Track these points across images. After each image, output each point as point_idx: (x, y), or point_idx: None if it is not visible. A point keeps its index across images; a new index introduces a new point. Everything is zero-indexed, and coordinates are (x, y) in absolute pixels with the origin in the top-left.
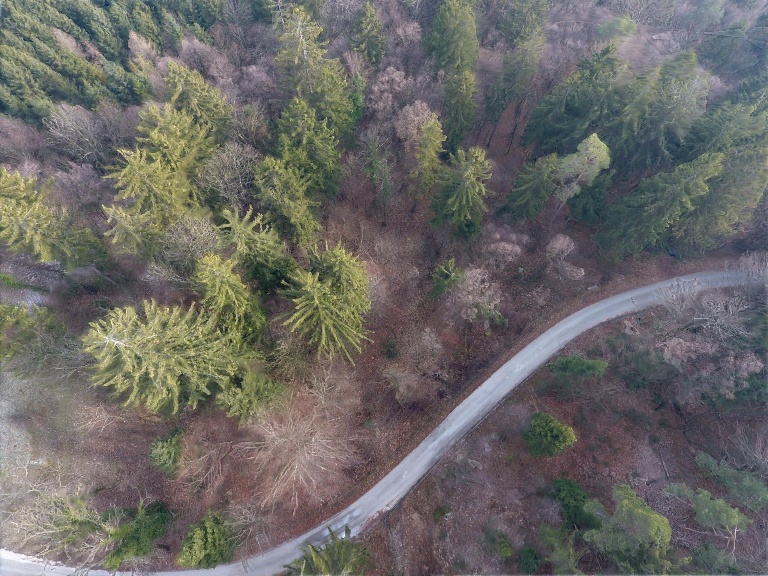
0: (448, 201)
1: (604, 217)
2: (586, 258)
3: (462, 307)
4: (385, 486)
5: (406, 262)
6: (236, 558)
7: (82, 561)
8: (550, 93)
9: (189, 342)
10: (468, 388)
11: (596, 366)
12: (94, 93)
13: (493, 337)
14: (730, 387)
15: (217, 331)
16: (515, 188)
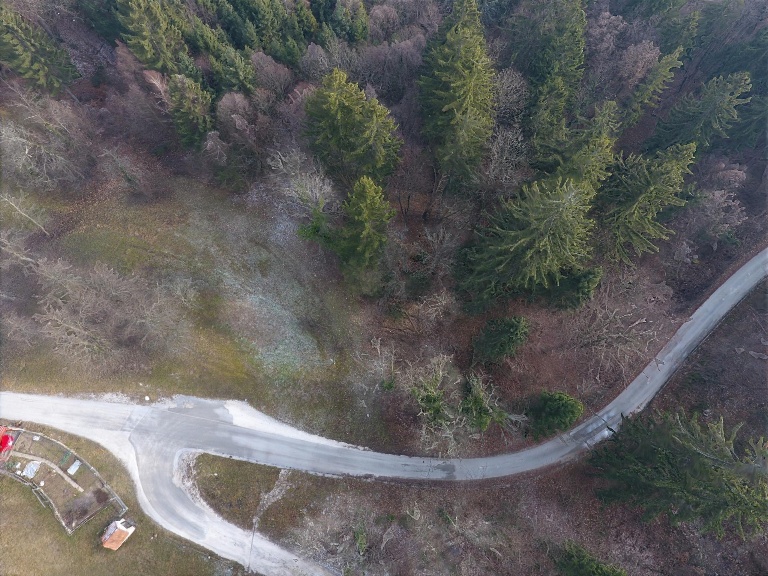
0: (696, 127)
1: None
2: None
3: (702, 227)
4: (633, 391)
5: None
6: (517, 448)
7: (386, 447)
8: (767, 34)
9: None
10: (691, 308)
11: None
12: (327, 35)
13: (702, 264)
14: None
15: (580, 216)
16: (742, 120)
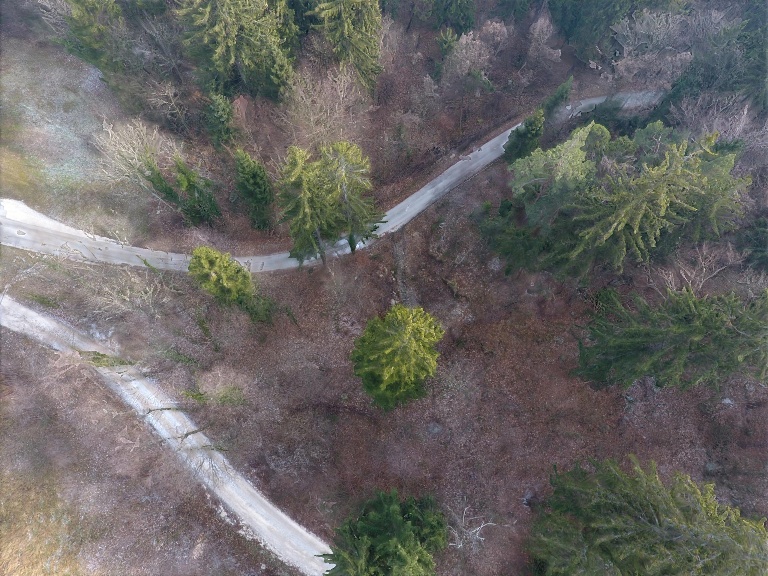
0: None
1: (580, 17)
2: (567, 75)
3: None
4: (391, 216)
5: (411, 85)
6: (268, 252)
7: (145, 243)
8: None
9: (245, 3)
10: (462, 153)
11: (564, 85)
12: None
13: (484, 122)
14: (668, 79)
15: (265, 3)
16: None
